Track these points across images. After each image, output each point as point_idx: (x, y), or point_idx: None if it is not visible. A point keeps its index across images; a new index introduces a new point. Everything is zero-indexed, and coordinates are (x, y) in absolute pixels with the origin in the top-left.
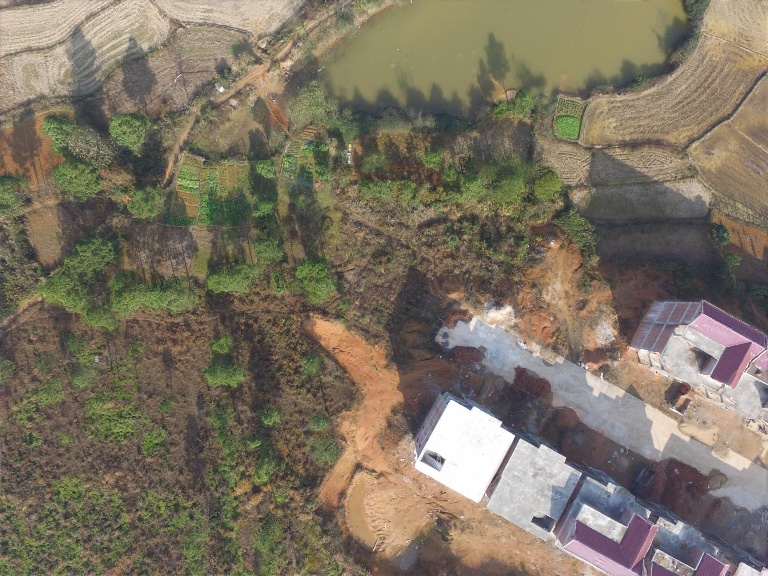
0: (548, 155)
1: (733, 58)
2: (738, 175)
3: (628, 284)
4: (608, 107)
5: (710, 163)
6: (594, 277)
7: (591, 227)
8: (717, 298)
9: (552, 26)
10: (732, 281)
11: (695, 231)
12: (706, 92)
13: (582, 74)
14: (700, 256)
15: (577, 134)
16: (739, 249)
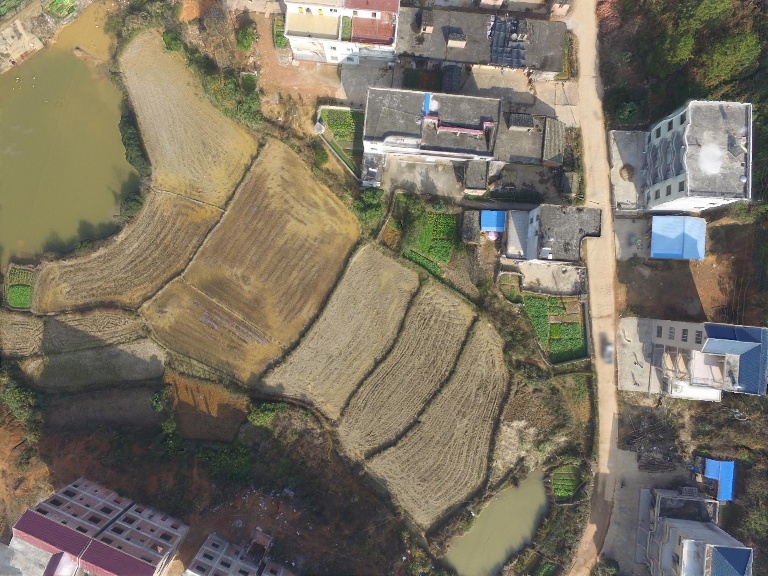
0: (0, 327)
1: (185, 211)
2: (192, 331)
3: (65, 458)
4: (61, 272)
5: (164, 321)
6: (30, 454)
7: (32, 401)
8: (152, 466)
9: (6, 192)
10: (165, 449)
11: (148, 393)
12: (158, 249)
13: (40, 238)
14: (153, 418)
15: (30, 302)
16: (193, 408)
